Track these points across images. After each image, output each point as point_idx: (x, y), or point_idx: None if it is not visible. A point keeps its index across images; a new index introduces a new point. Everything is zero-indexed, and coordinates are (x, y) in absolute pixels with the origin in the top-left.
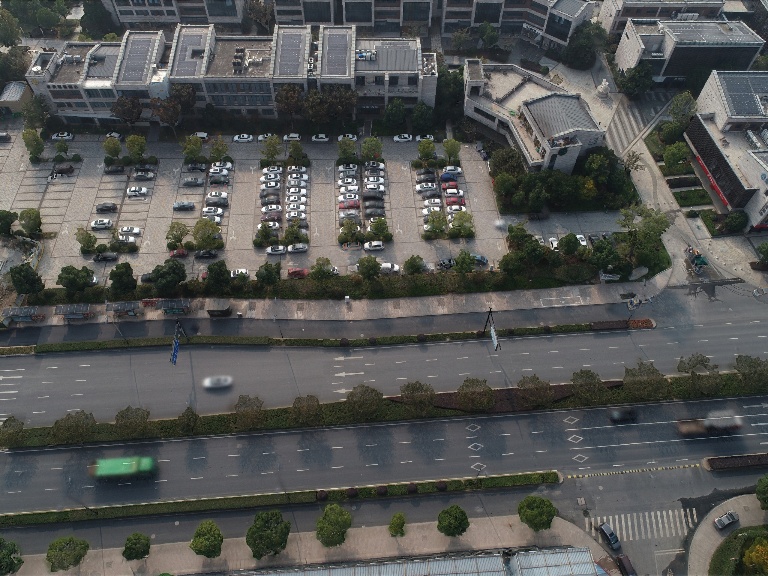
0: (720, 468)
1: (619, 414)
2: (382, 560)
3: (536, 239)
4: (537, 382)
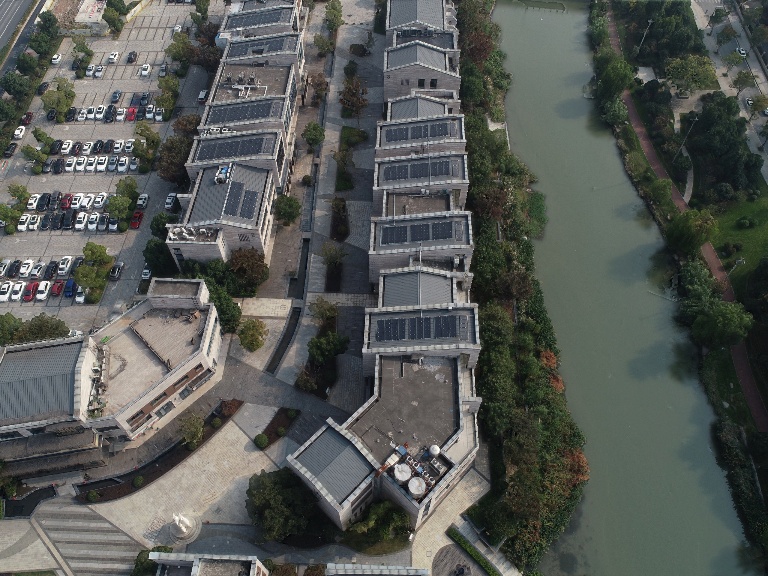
0: None
1: None
2: None
3: None
4: None
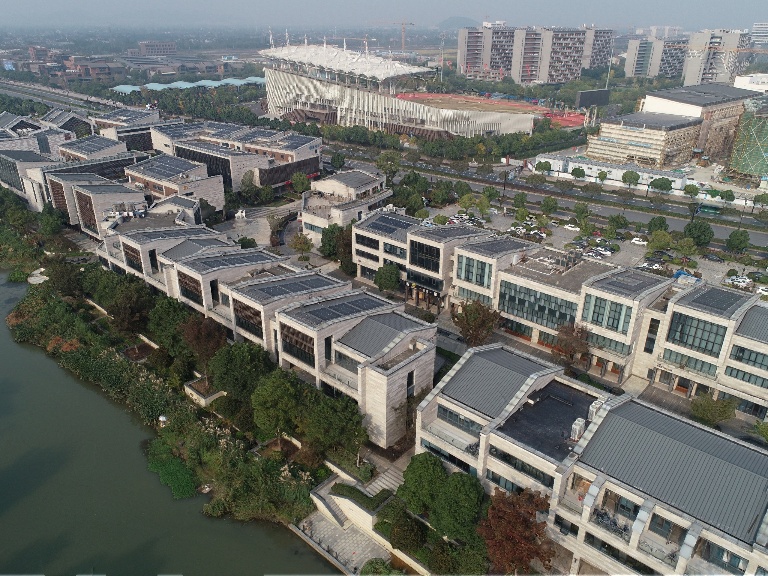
0: None
1: None
2: None
3: (443, 182)
4: None
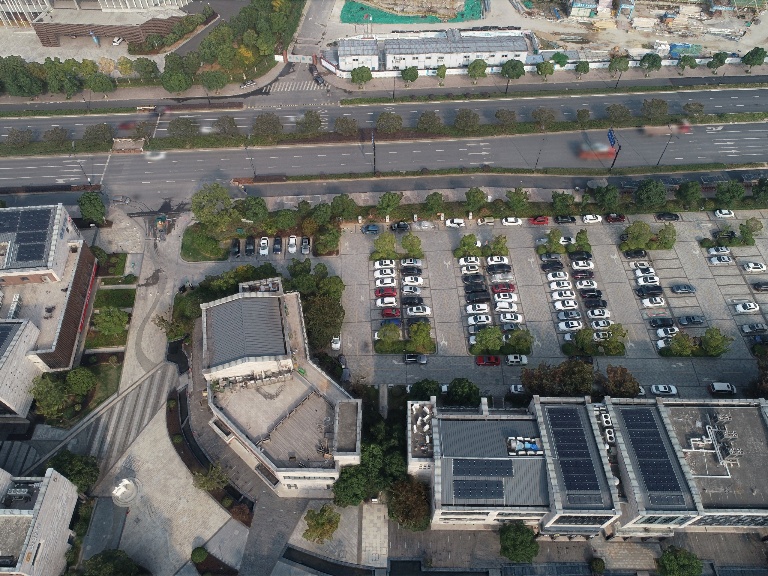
0: (237, 102)
1: (288, 130)
2: (448, 67)
3: (319, 212)
4: None
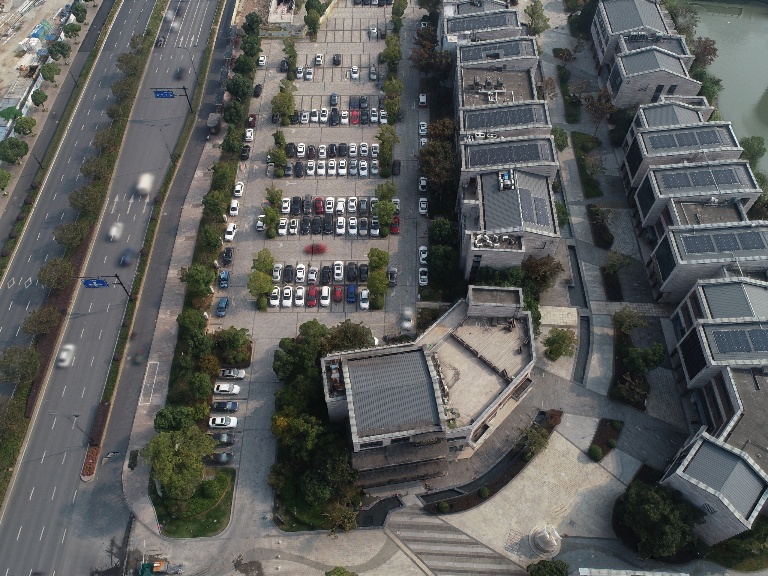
0: None
1: None
2: None
3: (205, 340)
4: (43, 318)
